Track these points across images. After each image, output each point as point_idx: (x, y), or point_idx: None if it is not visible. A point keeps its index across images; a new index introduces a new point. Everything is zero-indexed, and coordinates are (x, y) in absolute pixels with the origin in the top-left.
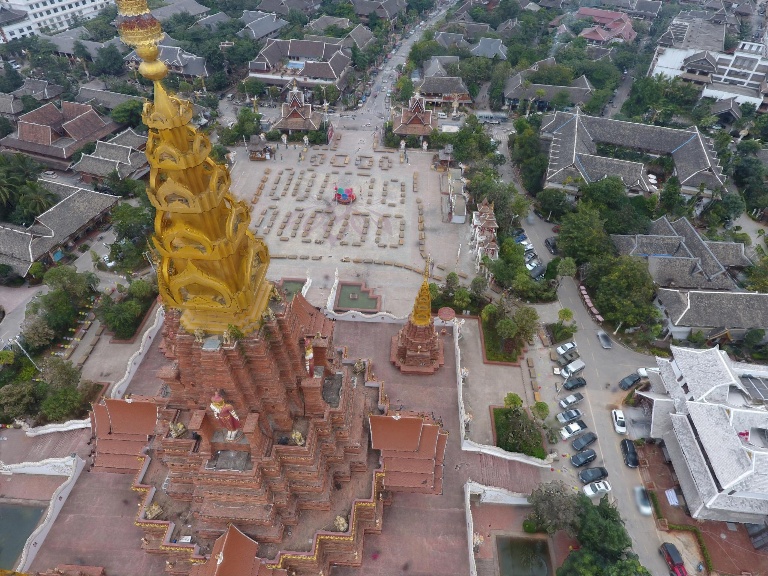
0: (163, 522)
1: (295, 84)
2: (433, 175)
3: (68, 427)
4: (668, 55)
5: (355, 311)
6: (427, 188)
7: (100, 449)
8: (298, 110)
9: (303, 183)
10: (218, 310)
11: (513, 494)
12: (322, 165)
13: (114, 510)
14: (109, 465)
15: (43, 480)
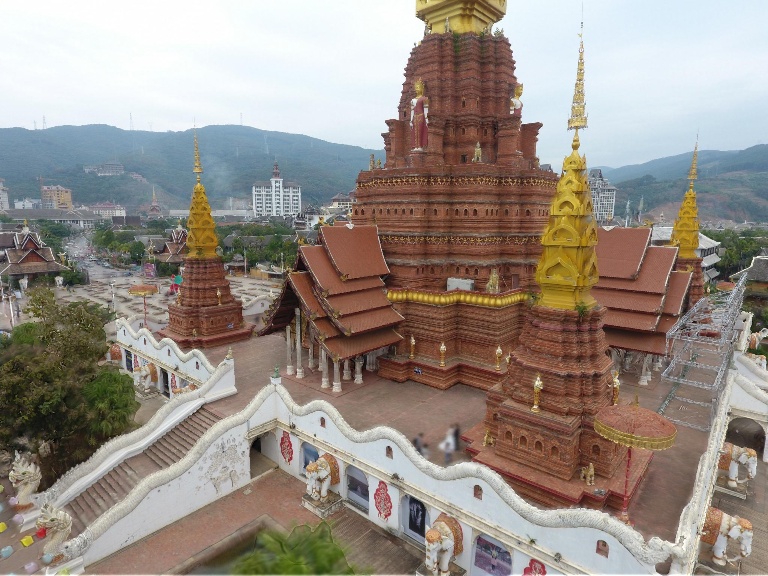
0: (515, 289)
1: (26, 224)
2: (238, 278)
3: (158, 427)
4: (316, 219)
5: None
6: (246, 281)
7: (340, 311)
8: (36, 252)
9: (106, 297)
10: (498, 7)
11: None
12: (108, 290)
13: (404, 405)
14: (366, 327)
15: (187, 524)
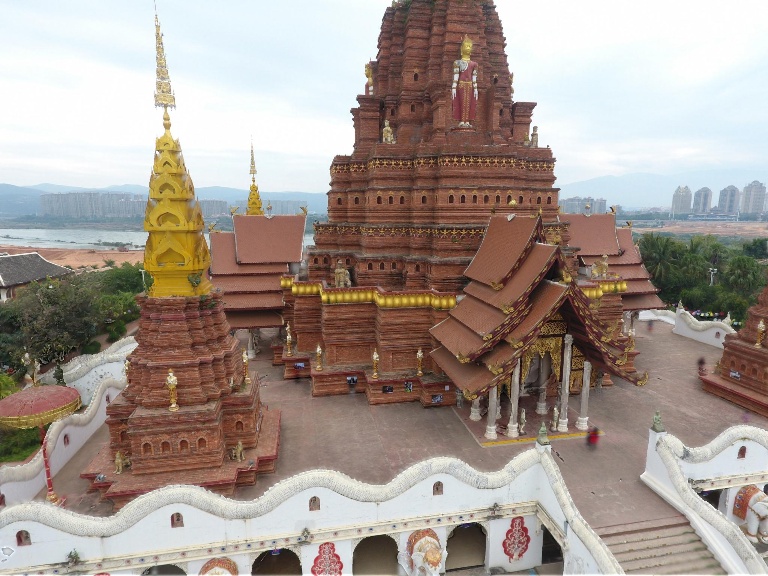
0: None
1: None
2: None
3: None
4: None
5: (431, 459)
6: None
7: None
8: None
9: None
10: None
11: None
12: None
13: None
14: None
15: None
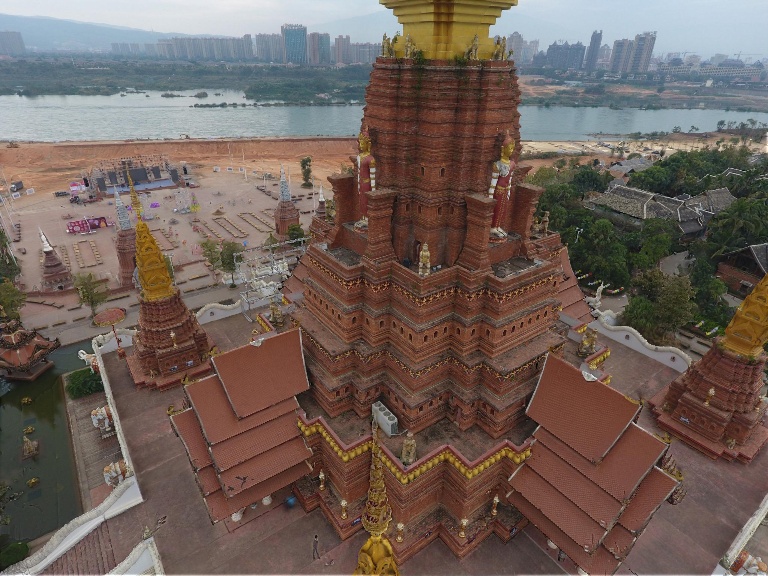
0: None
1: None
2: None
3: None
4: None
5: None
6: None
7: None
8: None
9: None
10: None
11: (42, 550)
12: None
13: None
14: None
15: None
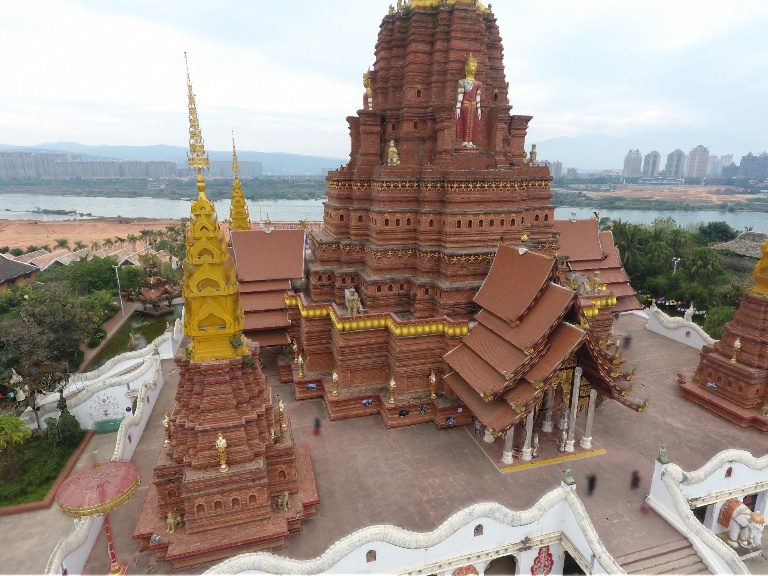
0: None
1: None
2: None
3: None
4: None
5: (473, 506)
6: None
7: None
8: None
9: None
10: None
11: None
12: None
13: None
14: None
15: None
